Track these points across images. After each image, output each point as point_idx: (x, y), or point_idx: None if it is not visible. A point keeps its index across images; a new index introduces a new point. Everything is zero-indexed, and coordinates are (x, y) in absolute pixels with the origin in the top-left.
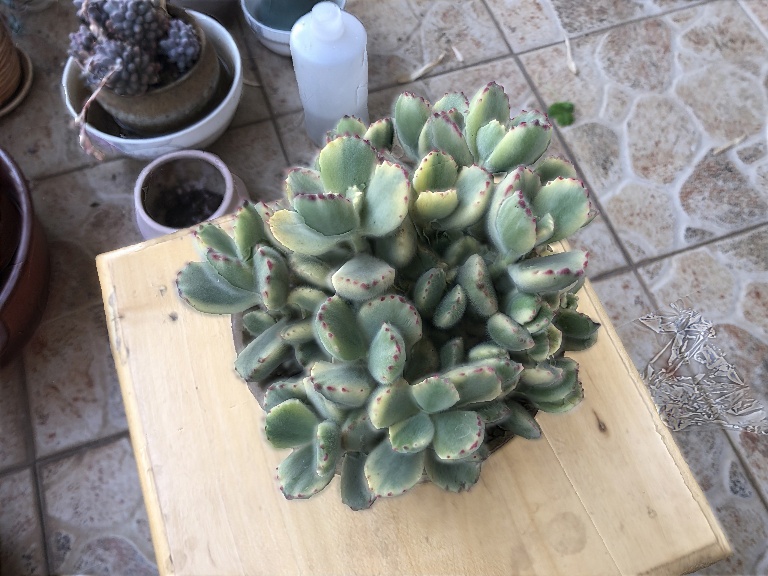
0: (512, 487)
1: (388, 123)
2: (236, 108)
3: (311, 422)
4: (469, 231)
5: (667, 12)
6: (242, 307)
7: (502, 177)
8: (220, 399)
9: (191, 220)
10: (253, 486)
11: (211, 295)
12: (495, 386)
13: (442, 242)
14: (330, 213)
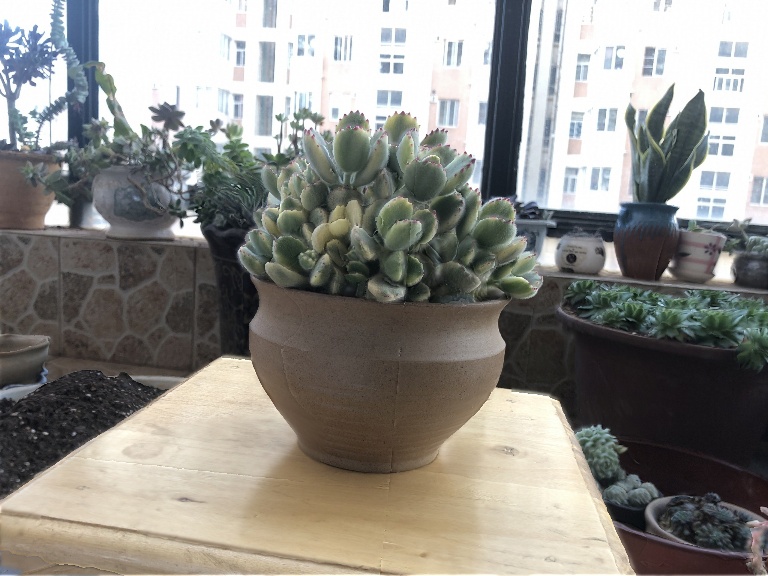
0: (210, 447)
1: None
2: None
3: None
4: None
5: None
6: None
7: (557, 575)
8: None
9: None
10: None
11: None
12: None
13: None
14: None
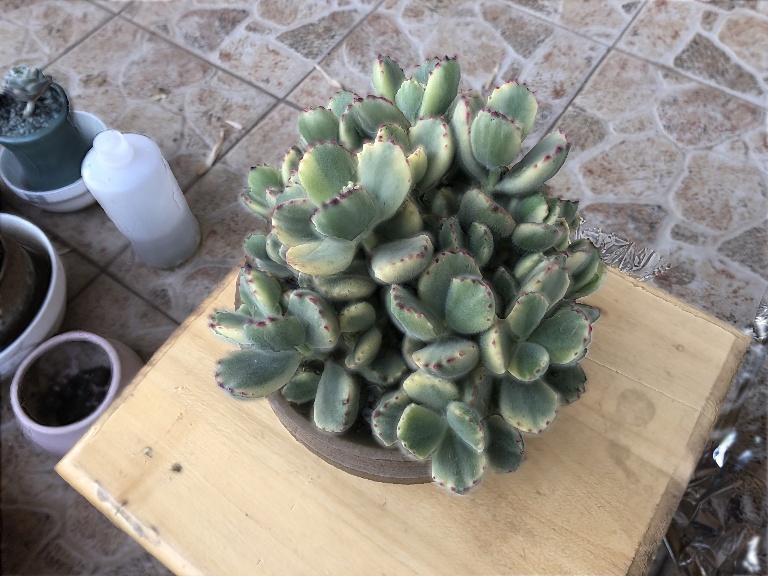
0: None
1: (296, 151)
2: (66, 279)
3: (433, 418)
4: (444, 181)
5: (378, 5)
6: (291, 371)
7: None
8: (276, 509)
9: (86, 407)
10: (363, 561)
11: (259, 377)
12: (564, 278)
13: (426, 205)
14: (356, 208)
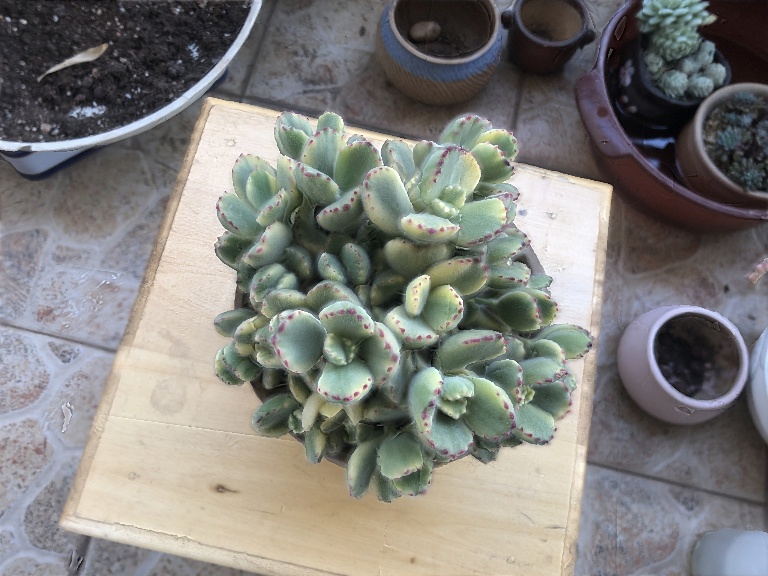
0: None
1: None
2: None
3: None
4: None
5: None
6: None
7: None
8: None
9: (671, 361)
10: None
11: None
12: None
13: None
14: None
